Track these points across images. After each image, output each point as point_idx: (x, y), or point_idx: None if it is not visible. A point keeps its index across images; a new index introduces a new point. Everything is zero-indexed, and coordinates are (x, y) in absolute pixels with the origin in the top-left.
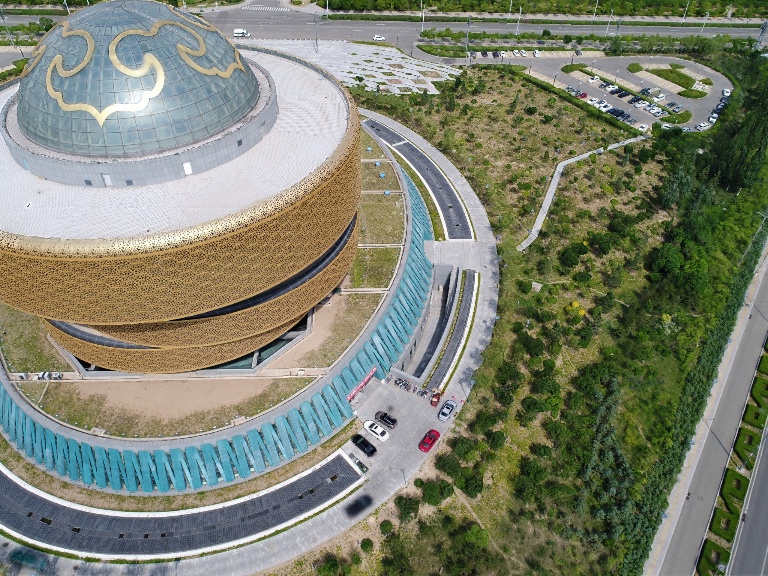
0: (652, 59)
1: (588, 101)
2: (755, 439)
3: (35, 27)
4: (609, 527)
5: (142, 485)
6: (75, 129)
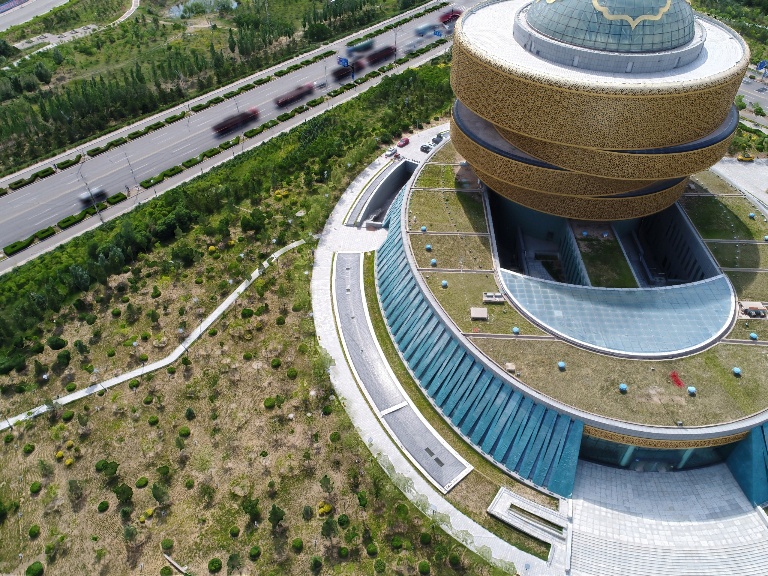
0: None
1: None
2: (224, 144)
3: None
4: (325, 122)
5: None
6: None
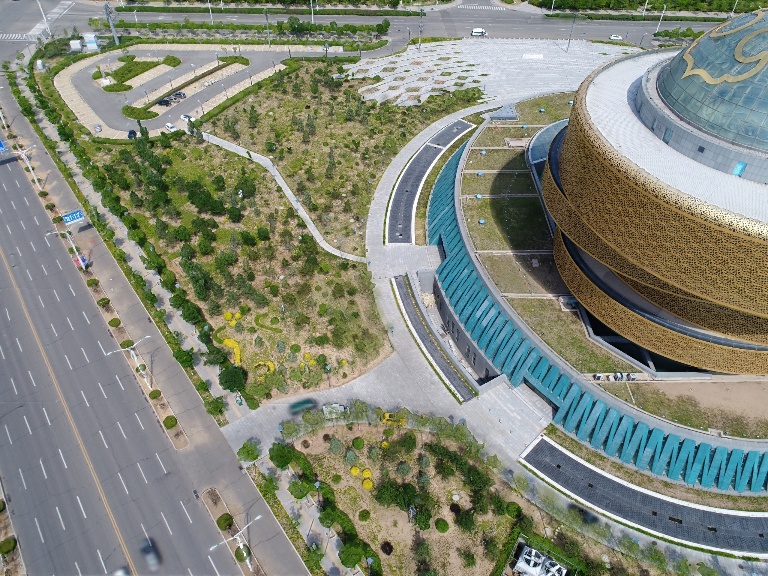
0: None
1: None
2: None
3: (287, 26)
4: None
5: (753, 485)
6: None
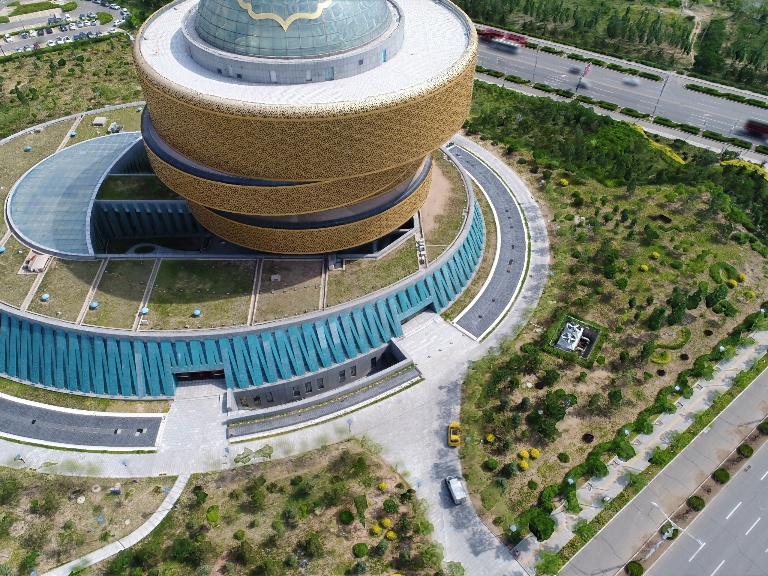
0: None
1: (50, 45)
2: None
3: None
4: None
5: None
6: (382, 6)
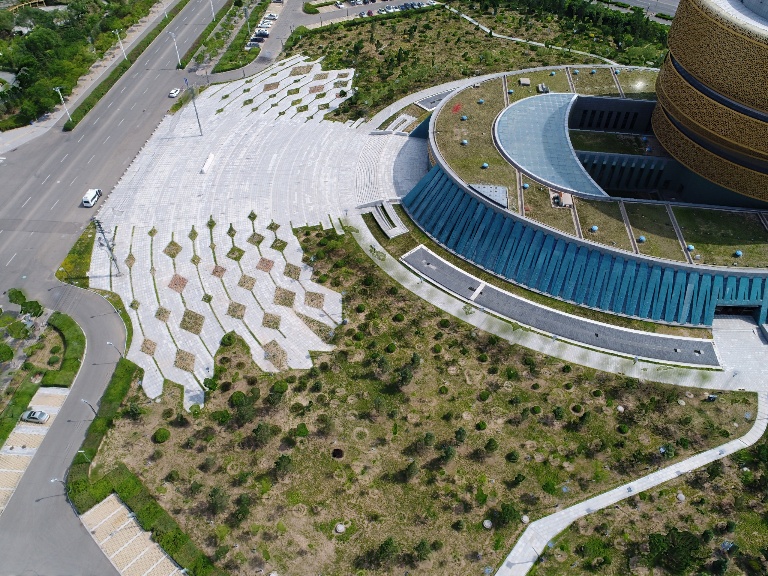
0: None
1: (383, 12)
2: None
3: None
4: None
5: None
6: None
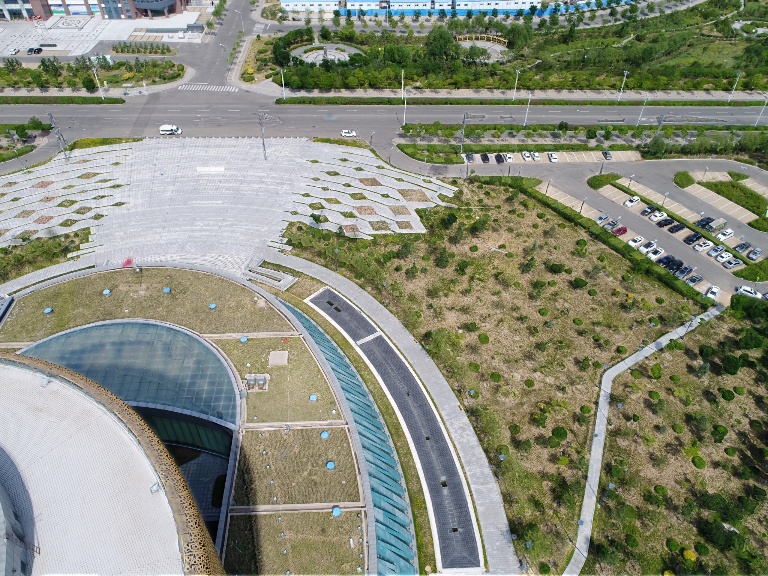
0: (703, 163)
1: (630, 242)
2: None
3: None
4: None
5: None
6: None
